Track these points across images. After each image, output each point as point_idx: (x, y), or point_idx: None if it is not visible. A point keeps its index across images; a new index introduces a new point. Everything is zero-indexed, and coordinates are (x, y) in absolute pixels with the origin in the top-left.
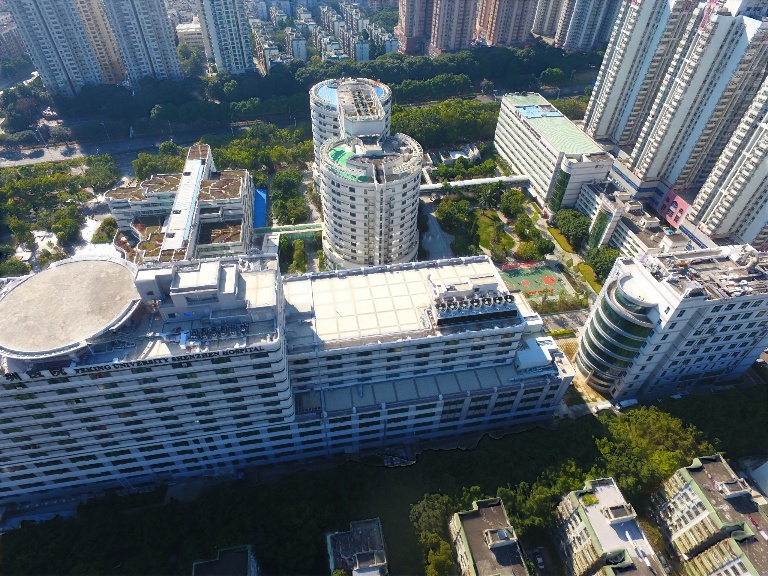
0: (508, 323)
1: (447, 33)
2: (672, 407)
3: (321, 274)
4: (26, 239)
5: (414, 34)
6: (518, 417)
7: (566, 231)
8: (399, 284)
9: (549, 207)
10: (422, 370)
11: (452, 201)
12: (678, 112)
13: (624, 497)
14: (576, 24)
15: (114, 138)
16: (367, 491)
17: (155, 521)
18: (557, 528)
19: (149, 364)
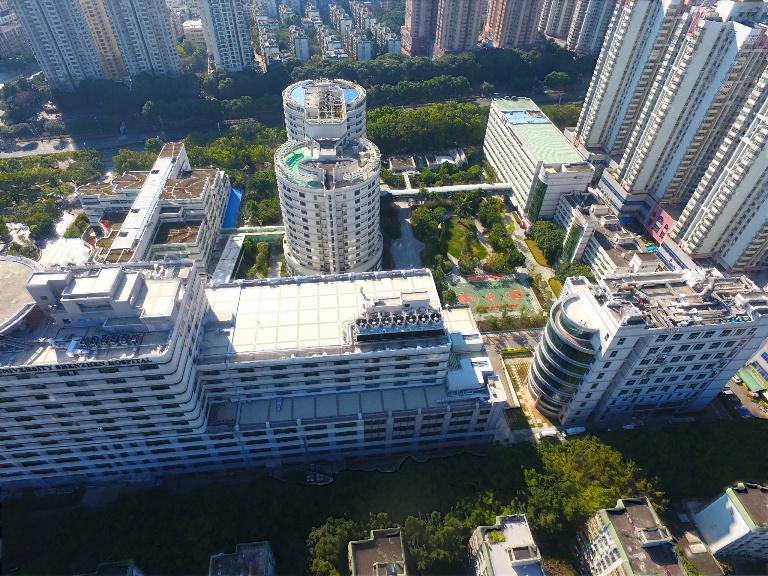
0: (434, 343)
1: (451, 34)
2: (614, 439)
3: (252, 281)
4: None
5: (420, 34)
6: (451, 440)
7: (540, 244)
8: (330, 295)
9: (528, 217)
10: (345, 386)
11: (427, 208)
12: (665, 122)
13: (542, 535)
14: (589, 26)
15: (107, 133)
16: (272, 510)
17: (58, 525)
18: (469, 562)
19: (33, 371)
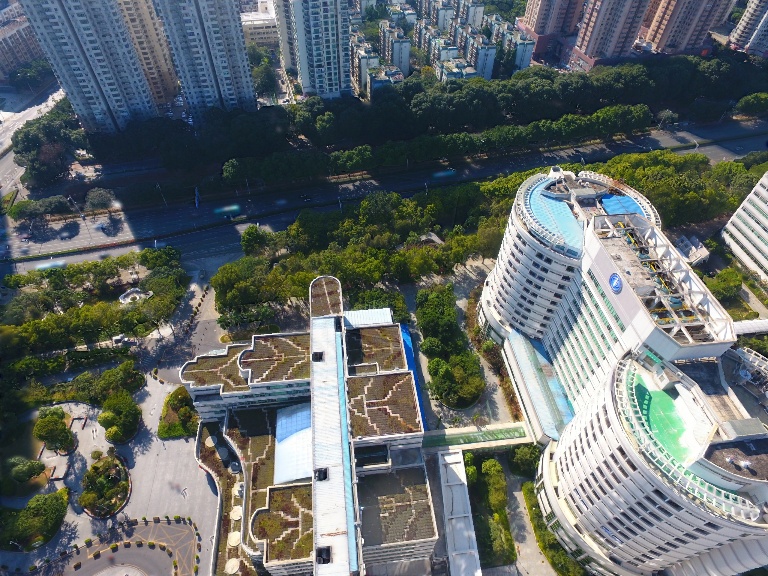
0: None
1: (604, 35)
2: None
3: None
4: (59, 445)
5: (548, 31)
6: None
7: None
8: None
9: None
10: None
11: None
12: None
13: None
14: None
15: (172, 202)
16: None
17: None
18: None
19: None
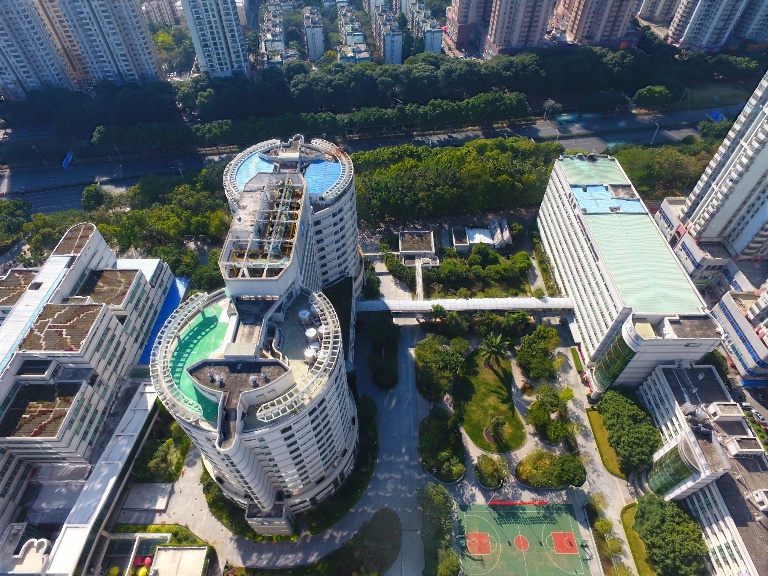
0: None
1: (510, 24)
2: None
3: None
4: None
5: (469, 20)
6: None
7: (613, 441)
8: None
9: (595, 374)
10: None
11: (440, 342)
12: None
13: None
14: (704, 12)
15: (53, 163)
16: None
17: None
18: None
19: None
